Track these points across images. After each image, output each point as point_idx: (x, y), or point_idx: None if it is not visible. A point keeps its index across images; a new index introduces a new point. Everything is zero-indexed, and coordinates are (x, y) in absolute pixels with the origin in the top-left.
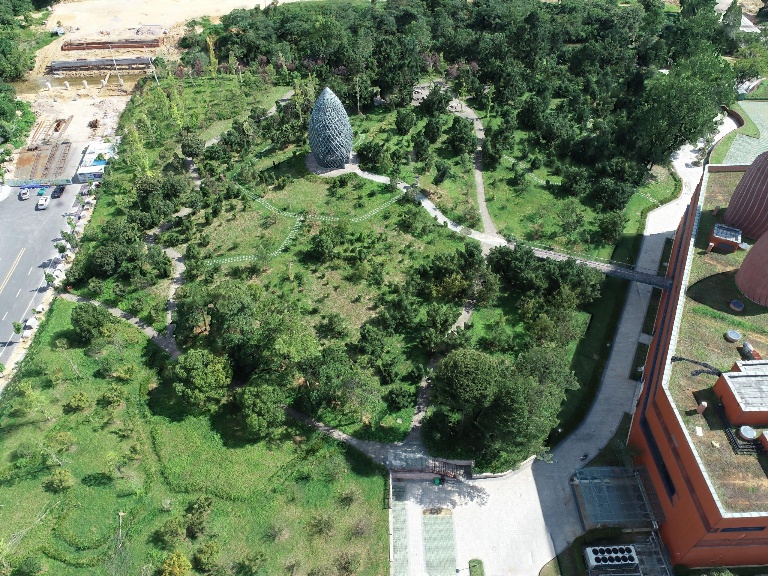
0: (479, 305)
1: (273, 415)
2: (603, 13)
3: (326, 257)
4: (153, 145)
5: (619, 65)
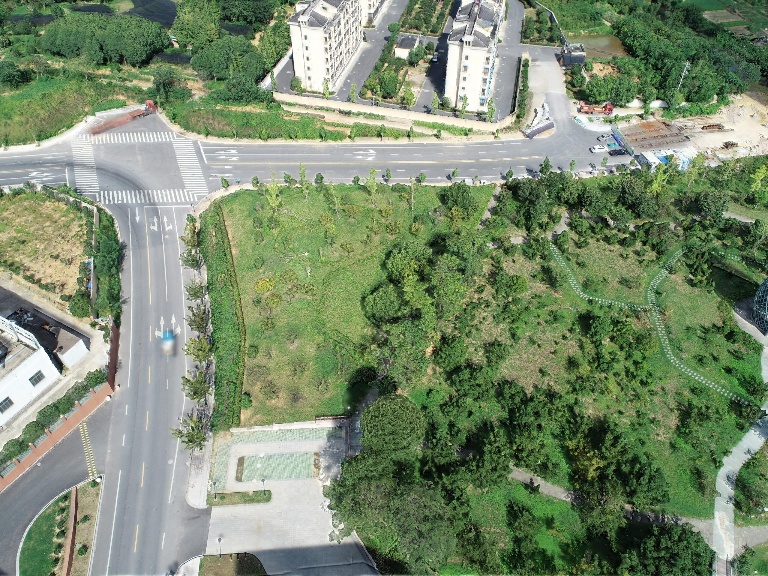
0: (583, 511)
1: (377, 312)
2: None
3: (589, 333)
4: (717, 185)
5: None
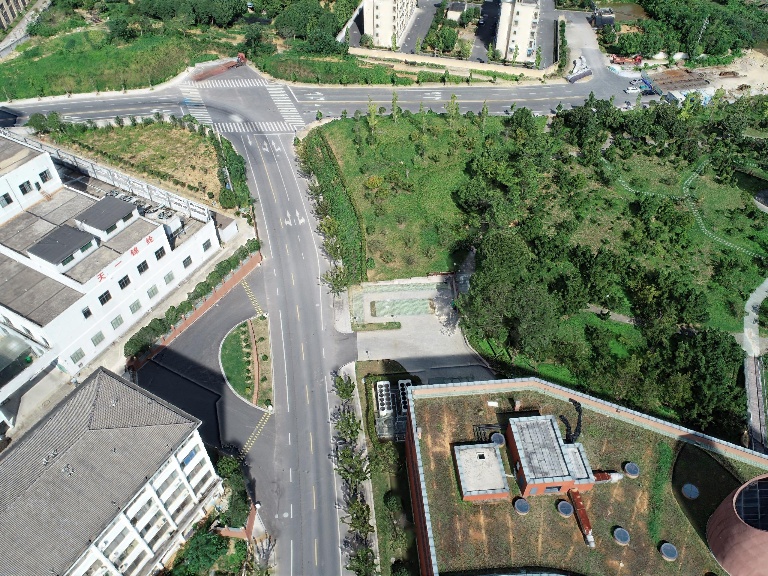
0: (643, 329)
1: (470, 197)
2: None
3: (639, 213)
4: None
5: None
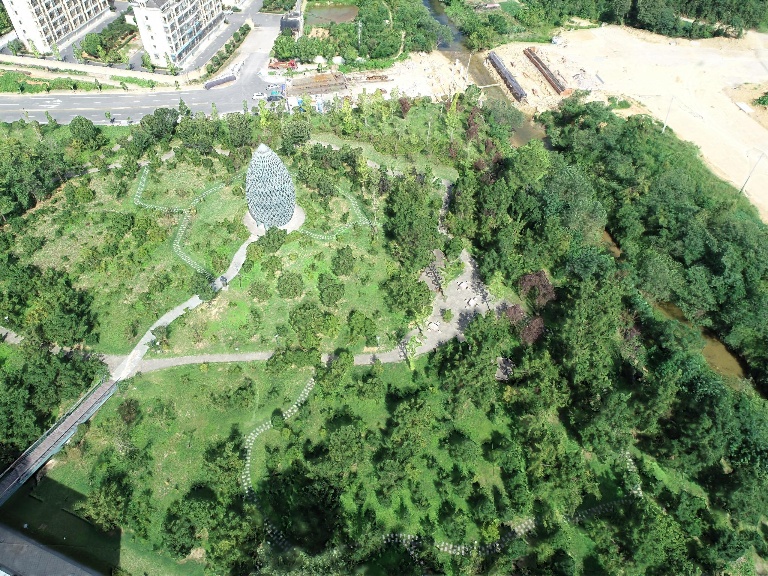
0: None
1: None
2: None
3: None
4: None
5: None
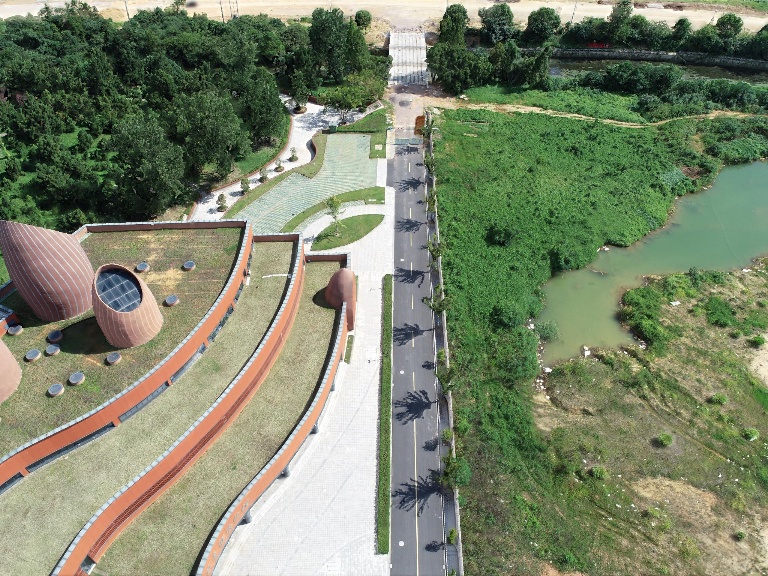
0: None
1: None
2: (261, 34)
3: None
4: None
5: None
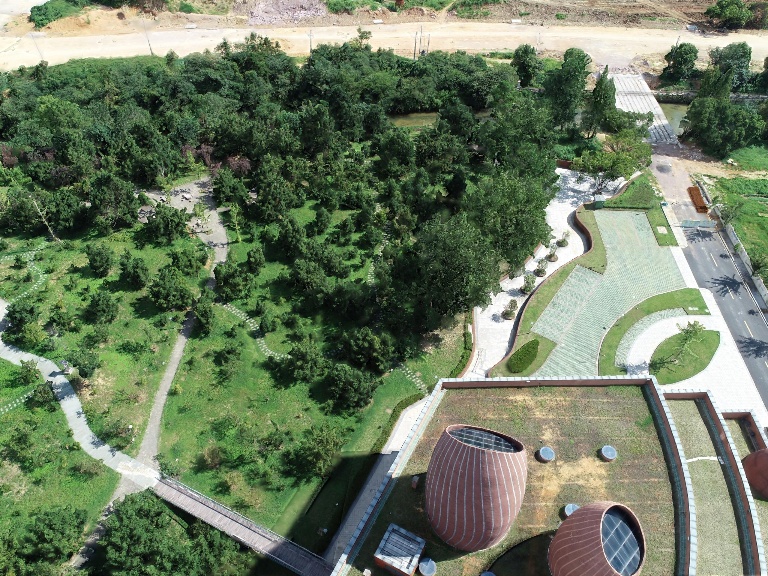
0: None
1: None
2: (463, 76)
3: None
4: None
5: (443, 160)
